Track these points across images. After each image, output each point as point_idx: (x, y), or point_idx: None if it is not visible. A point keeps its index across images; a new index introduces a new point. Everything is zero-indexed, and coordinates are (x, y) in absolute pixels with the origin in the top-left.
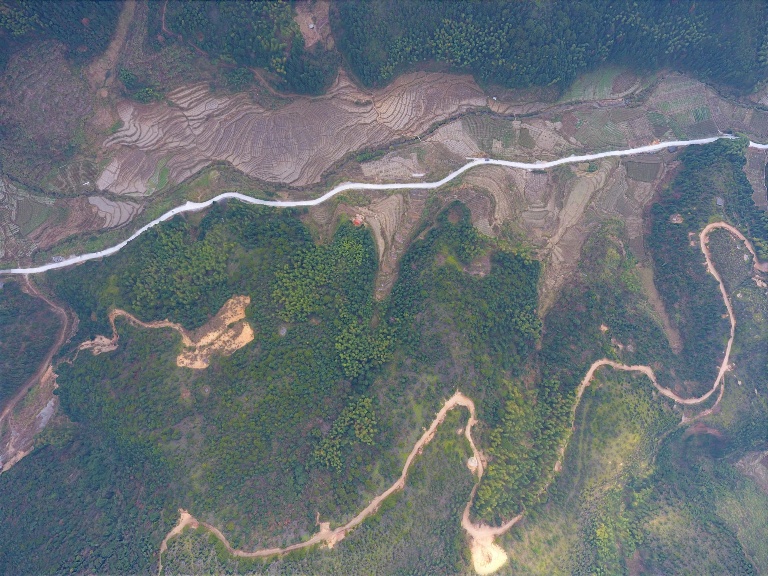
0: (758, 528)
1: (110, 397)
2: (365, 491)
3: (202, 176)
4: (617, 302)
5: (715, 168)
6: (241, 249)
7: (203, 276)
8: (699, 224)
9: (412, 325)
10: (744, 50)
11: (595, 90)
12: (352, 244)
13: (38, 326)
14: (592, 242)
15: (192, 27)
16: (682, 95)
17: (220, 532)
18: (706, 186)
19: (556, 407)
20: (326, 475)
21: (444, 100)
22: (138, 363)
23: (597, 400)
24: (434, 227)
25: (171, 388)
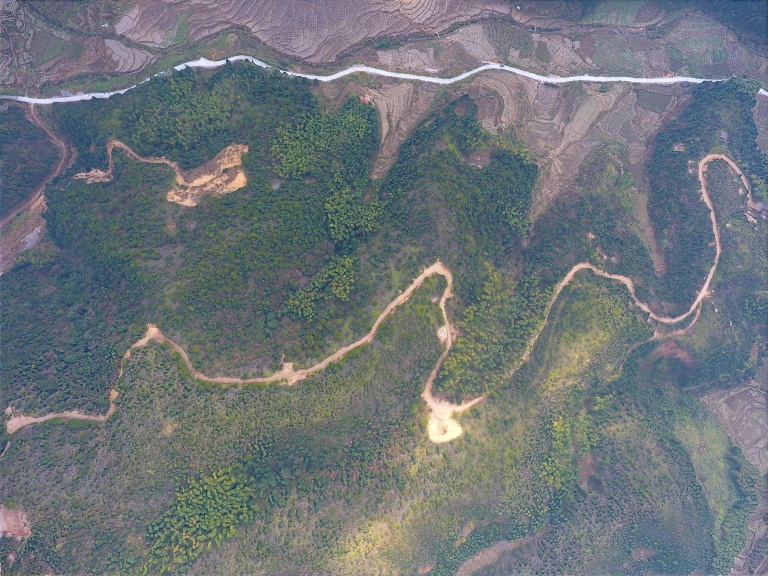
0: (713, 459)
1: (96, 217)
2: (333, 341)
3: (220, 37)
4: (608, 215)
5: (724, 104)
6: (247, 103)
7: (206, 123)
8: (700, 153)
9: (403, 201)
10: None
11: (618, 16)
12: (357, 118)
13: (36, 152)
14: (592, 158)
15: None
16: (703, 35)
17: (184, 352)
18: (712, 119)
19: (532, 300)
20: (297, 324)
21: (468, 2)
22: (129, 191)
23: (574, 297)
24: (440, 117)
25: (158, 217)
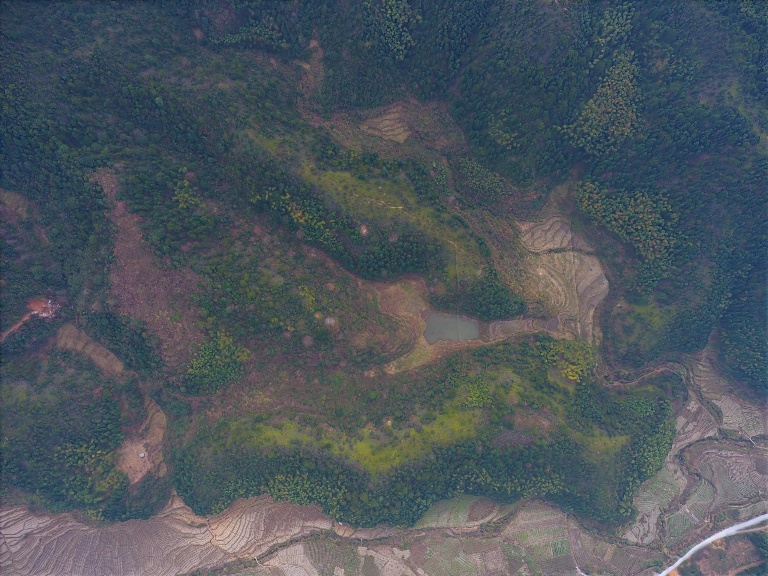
0: None
1: None
2: None
3: None
4: None
5: None
6: None
7: None
8: None
9: None
10: (604, 503)
11: (450, 516)
12: None
13: None
14: None
15: (2, 473)
16: (542, 526)
17: None
18: None
19: None
20: None
21: (287, 520)
22: None
23: None
24: None
25: None
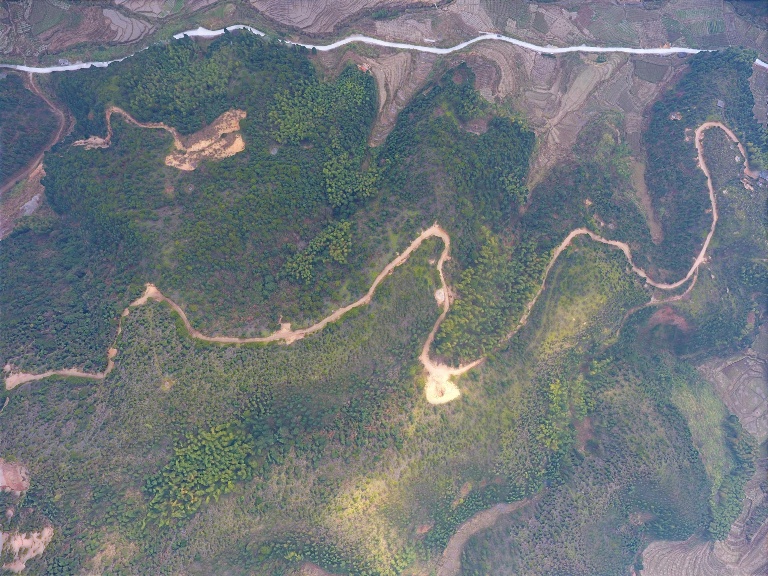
0: (710, 426)
1: (95, 180)
2: (330, 302)
3: (218, 7)
4: (605, 183)
5: (721, 73)
6: (245, 70)
7: (204, 90)
8: (697, 121)
9: (401, 166)
10: None
11: None
12: (354, 85)
13: (35, 120)
14: (590, 127)
15: None
16: (699, 6)
17: (183, 311)
18: (709, 88)
19: (530, 265)
20: (295, 287)
21: None
22: (127, 155)
23: (571, 262)
24: None
25: (156, 181)
